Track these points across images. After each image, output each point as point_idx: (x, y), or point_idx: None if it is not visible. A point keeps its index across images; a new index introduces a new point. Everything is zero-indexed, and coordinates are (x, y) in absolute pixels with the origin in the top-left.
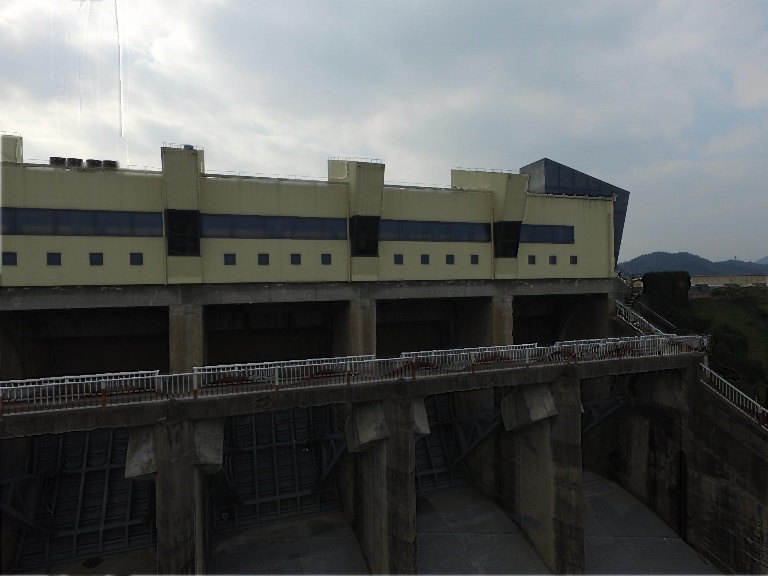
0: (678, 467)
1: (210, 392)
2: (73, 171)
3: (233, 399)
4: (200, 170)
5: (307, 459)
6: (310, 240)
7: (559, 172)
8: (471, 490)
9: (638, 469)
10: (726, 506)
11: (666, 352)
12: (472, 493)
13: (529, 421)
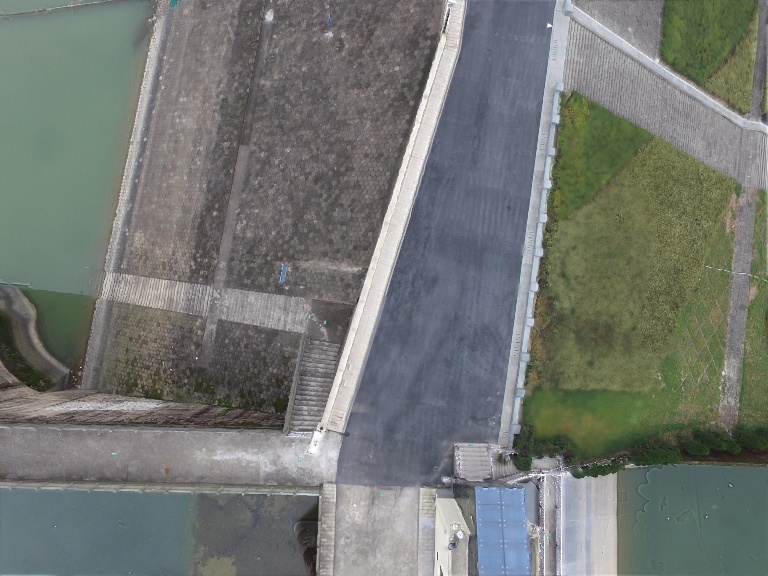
0: None
1: None
2: None
3: None
4: None
5: None
6: None
7: None
8: None
9: None
10: None
11: None
12: None
13: None
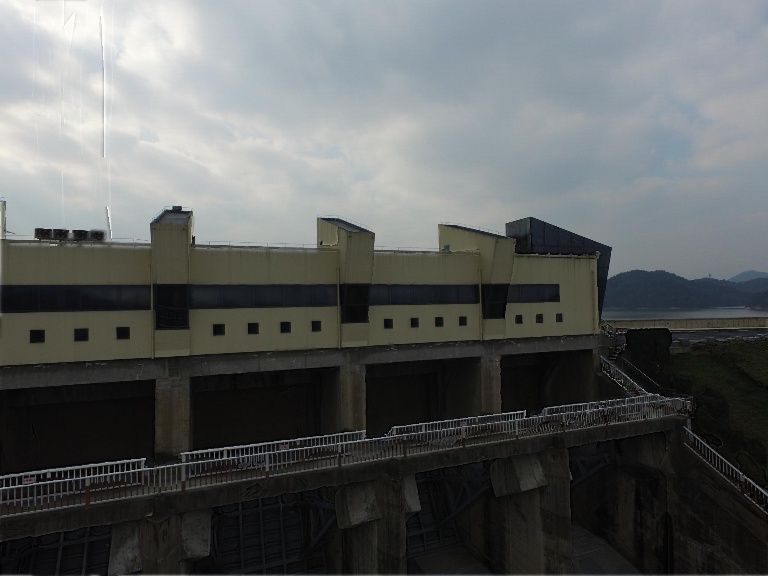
0: (664, 529)
1: (198, 482)
2: (60, 246)
3: (222, 489)
4: (190, 240)
5: (294, 522)
6: (300, 307)
7: (544, 230)
8: (460, 550)
9: (625, 527)
10: (712, 572)
11: (651, 416)
12: (461, 554)
13: (519, 491)
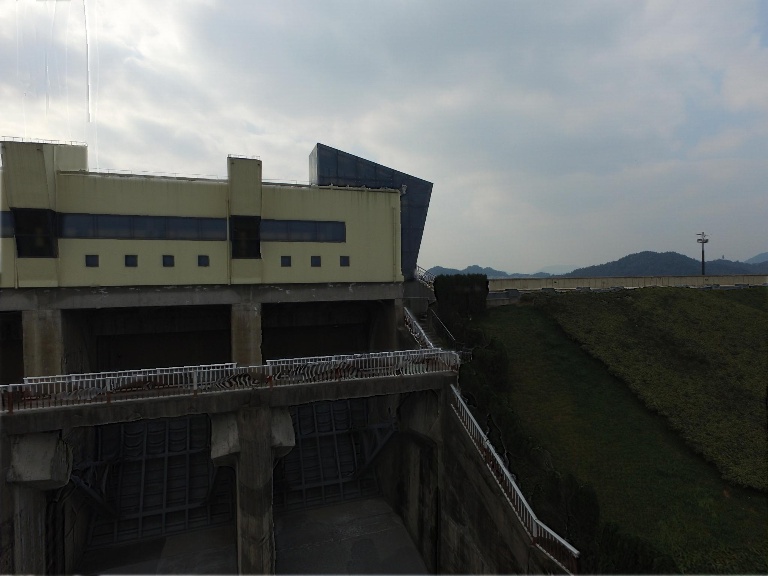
0: (436, 506)
1: None
2: None
3: None
4: None
5: None
6: None
7: (337, 160)
8: (228, 528)
9: (413, 504)
10: (463, 558)
11: (408, 371)
12: (225, 533)
13: None
